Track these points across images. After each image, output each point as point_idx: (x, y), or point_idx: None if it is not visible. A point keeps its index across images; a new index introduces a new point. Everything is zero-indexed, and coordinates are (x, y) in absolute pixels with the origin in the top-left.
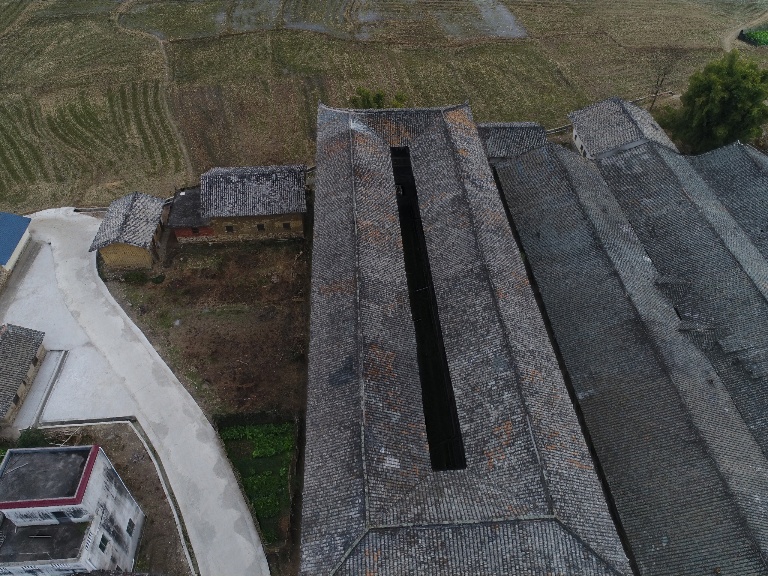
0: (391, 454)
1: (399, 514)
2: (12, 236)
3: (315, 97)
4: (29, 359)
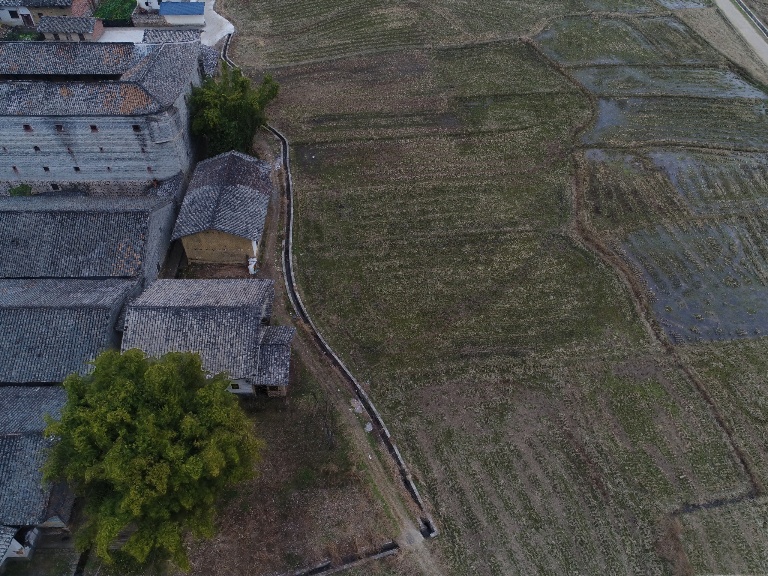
0: None
1: None
2: (184, 11)
3: (404, 120)
4: (73, 31)
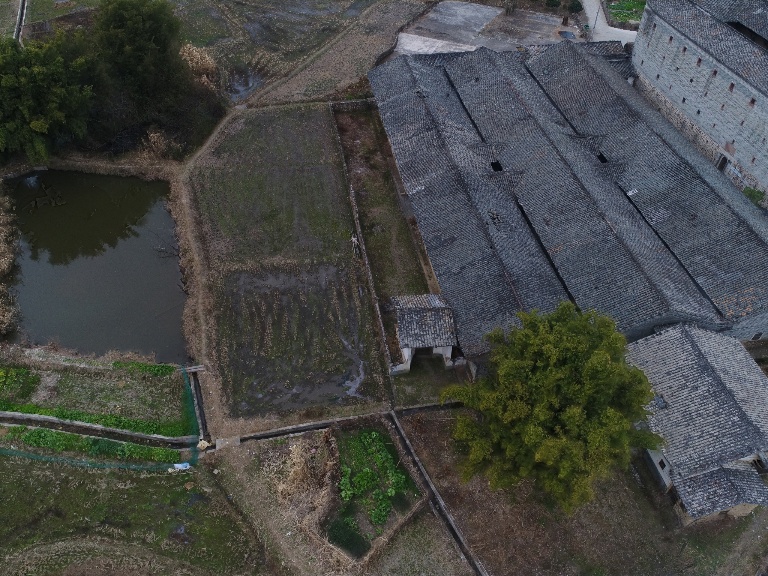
0: (761, 13)
1: (744, 0)
2: None
3: None
4: None
